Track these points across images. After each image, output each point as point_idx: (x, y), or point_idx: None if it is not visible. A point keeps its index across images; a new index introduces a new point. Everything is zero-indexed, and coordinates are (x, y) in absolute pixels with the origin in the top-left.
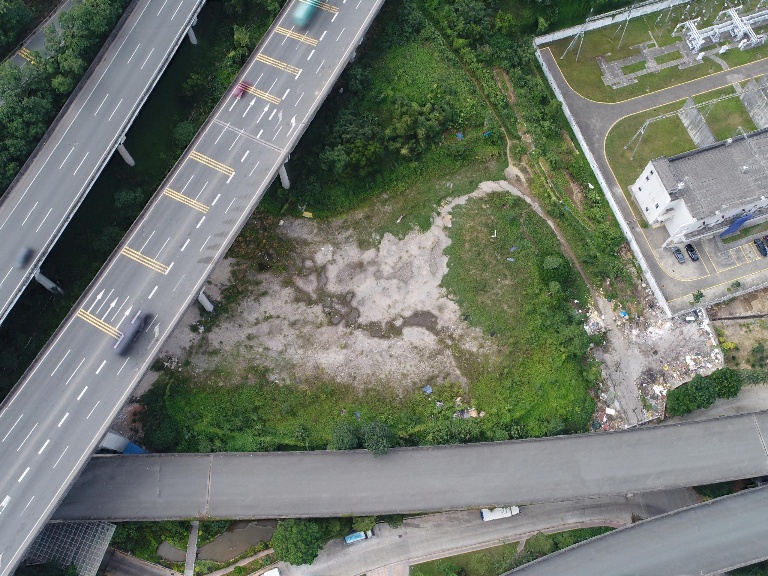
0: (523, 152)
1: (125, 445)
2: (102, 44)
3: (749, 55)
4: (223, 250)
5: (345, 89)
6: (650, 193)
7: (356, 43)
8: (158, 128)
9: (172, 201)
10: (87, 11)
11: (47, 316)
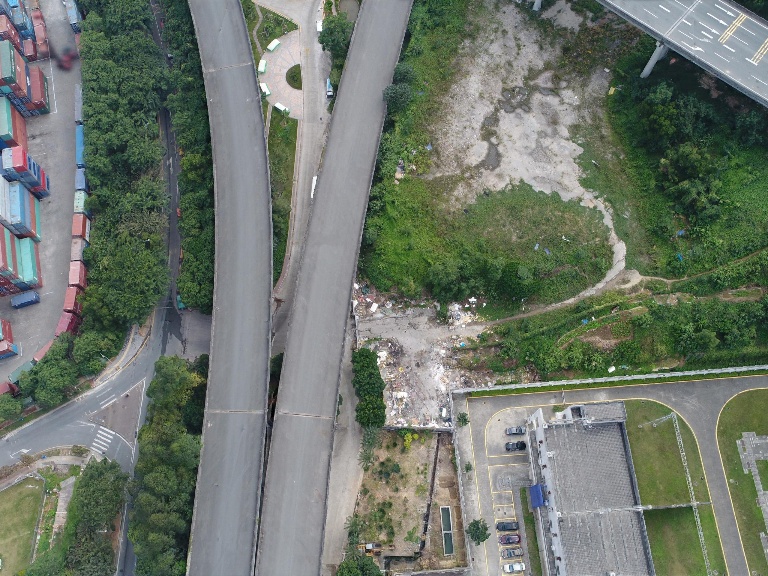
0: None
1: None
2: None
3: None
4: None
5: None
6: None
7: None
8: None
9: None
10: None
11: None
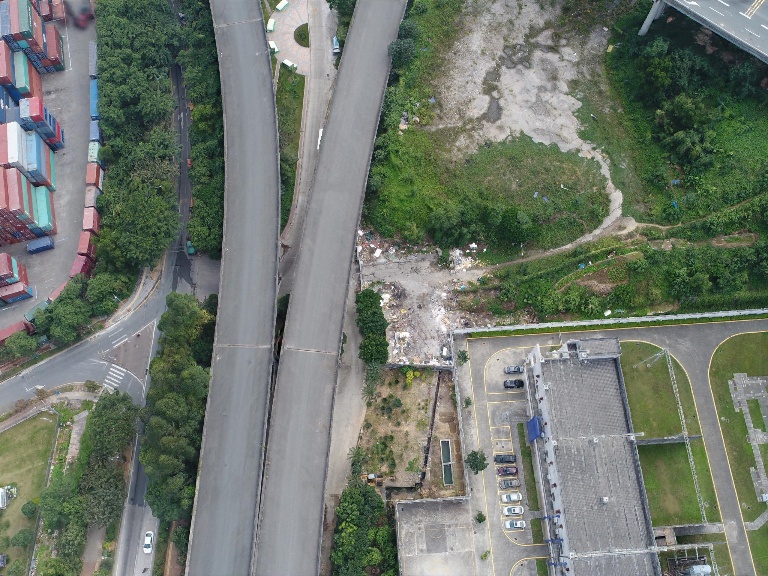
0: None
1: None
2: None
3: (766, 565)
4: None
5: None
6: None
7: None
8: None
9: None
10: None
11: None
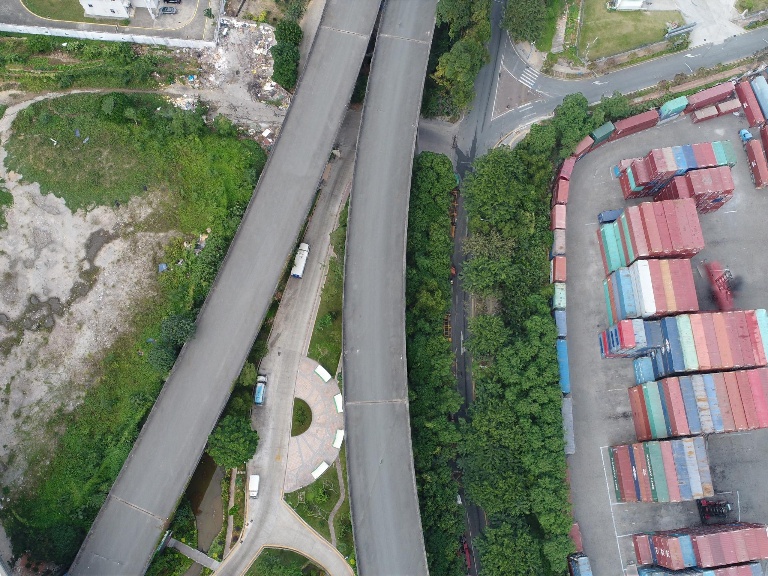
0: None
1: None
2: None
3: None
4: None
5: None
6: None
7: None
8: None
9: None
10: None
11: None
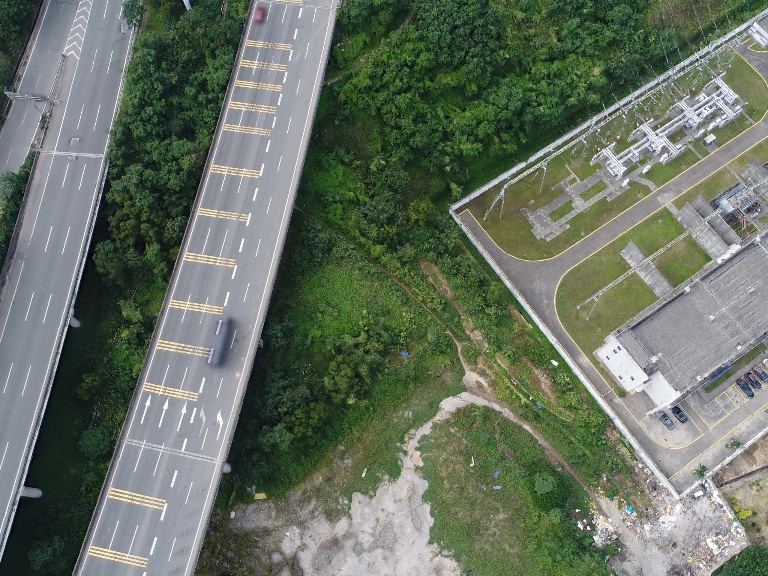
0: (477, 354)
1: None
2: None
3: (673, 168)
4: None
5: (266, 342)
6: (621, 365)
7: (267, 301)
8: (59, 441)
9: (101, 562)
10: None
11: None
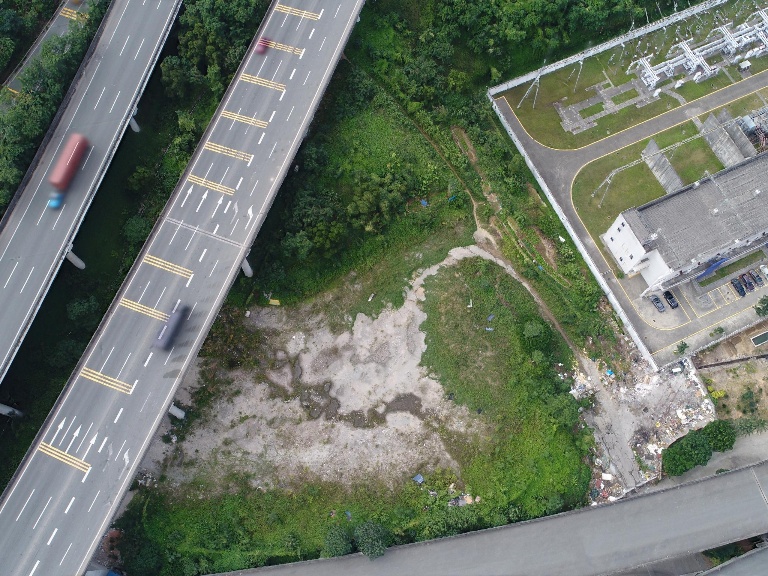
0: (490, 213)
1: (104, 575)
2: (38, 146)
3: (705, 87)
4: (189, 361)
5: (301, 167)
6: (623, 244)
7: (308, 122)
8: (107, 225)
9: (129, 312)
10: (18, 115)
11: (6, 443)
